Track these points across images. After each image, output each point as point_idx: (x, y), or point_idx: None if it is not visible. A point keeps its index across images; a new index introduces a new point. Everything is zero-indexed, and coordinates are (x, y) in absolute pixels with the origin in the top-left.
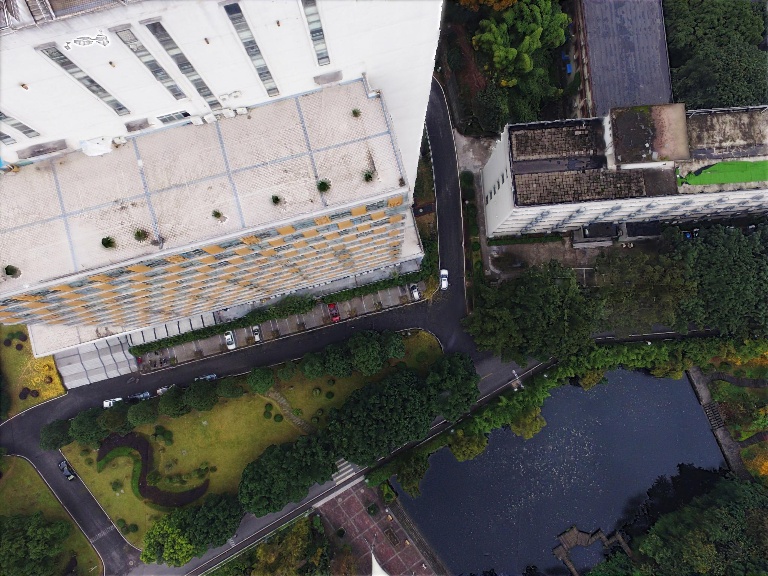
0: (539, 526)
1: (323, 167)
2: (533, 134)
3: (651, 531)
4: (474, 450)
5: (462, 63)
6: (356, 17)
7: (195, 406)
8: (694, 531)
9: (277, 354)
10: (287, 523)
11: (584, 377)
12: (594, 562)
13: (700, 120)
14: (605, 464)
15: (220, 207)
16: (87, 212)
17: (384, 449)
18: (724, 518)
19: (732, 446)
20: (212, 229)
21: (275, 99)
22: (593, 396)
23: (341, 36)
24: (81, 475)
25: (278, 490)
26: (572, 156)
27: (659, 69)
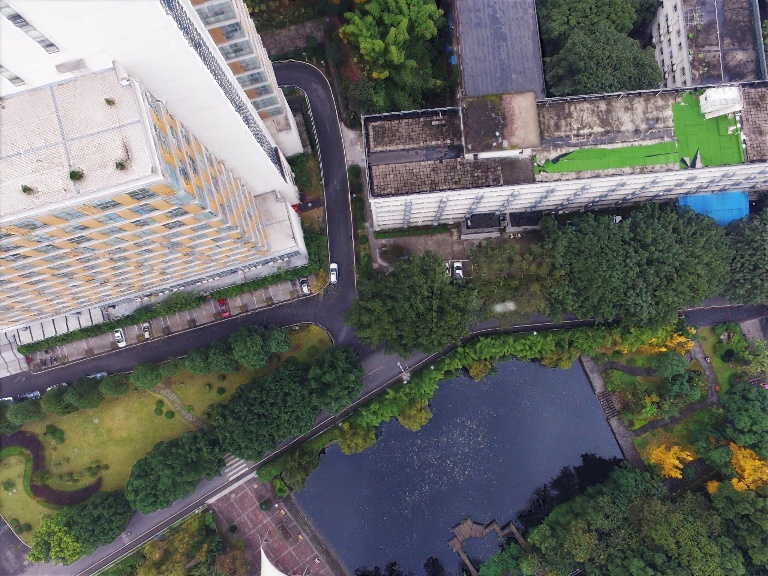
0: (433, 518)
1: (76, 156)
2: (390, 125)
3: (545, 521)
4: (359, 443)
5: (341, 56)
6: (53, 3)
7: (76, 404)
8: (577, 520)
9: (168, 351)
10: (180, 520)
11: (470, 368)
12: (489, 553)
13: (558, 108)
14: (499, 455)
15: None
16: None
17: (265, 443)
18: (606, 506)
19: (626, 435)
20: None
21: (28, 89)
22: (487, 387)
23: (51, 23)
24: None
25: (163, 486)
26: (429, 146)
27: (531, 59)
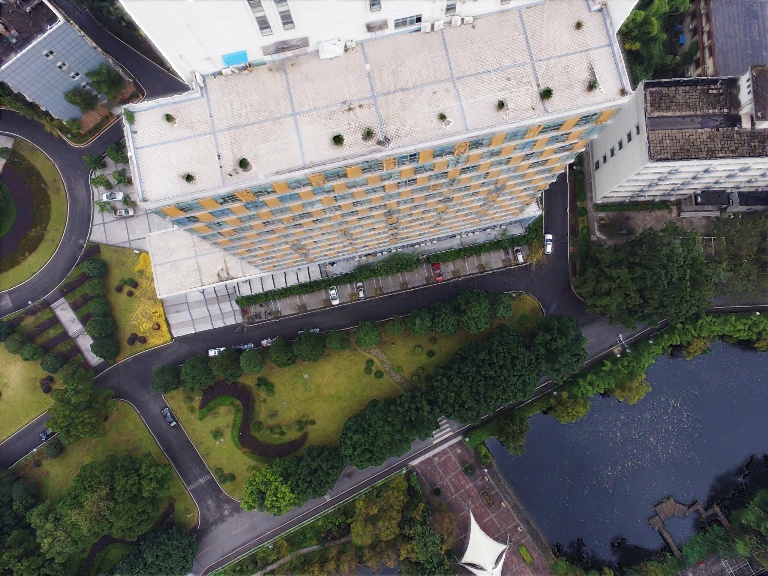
0: (635, 495)
1: (545, 76)
2: (667, 91)
3: (751, 505)
4: (579, 412)
5: None
6: None
7: (306, 355)
8: None
9: (379, 311)
10: (383, 479)
11: (691, 345)
12: (691, 534)
13: None
14: (704, 436)
15: (444, 111)
16: (316, 112)
17: (492, 405)
18: None
19: None
20: (437, 132)
21: (500, 10)
22: (693, 367)
23: None
24: (182, 422)
25: (382, 443)
26: (706, 114)
27: None
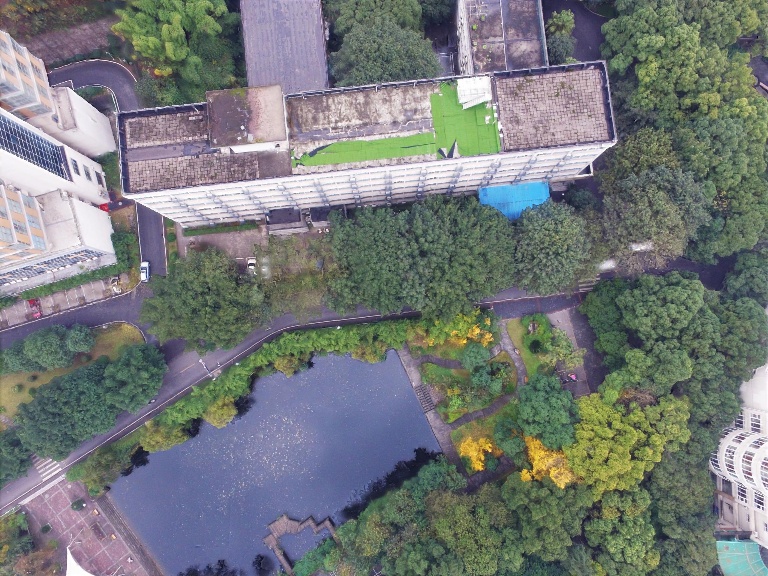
0: (249, 516)
1: None
2: (147, 121)
3: (359, 517)
4: (159, 441)
5: None
6: None
7: None
8: (373, 514)
9: None
10: None
11: (274, 364)
12: (305, 550)
13: (316, 101)
14: (316, 451)
15: None
16: None
17: (58, 443)
18: (400, 500)
19: (443, 428)
20: None
21: None
22: (304, 383)
23: None
24: None
25: None
26: (187, 141)
27: (315, 53)
